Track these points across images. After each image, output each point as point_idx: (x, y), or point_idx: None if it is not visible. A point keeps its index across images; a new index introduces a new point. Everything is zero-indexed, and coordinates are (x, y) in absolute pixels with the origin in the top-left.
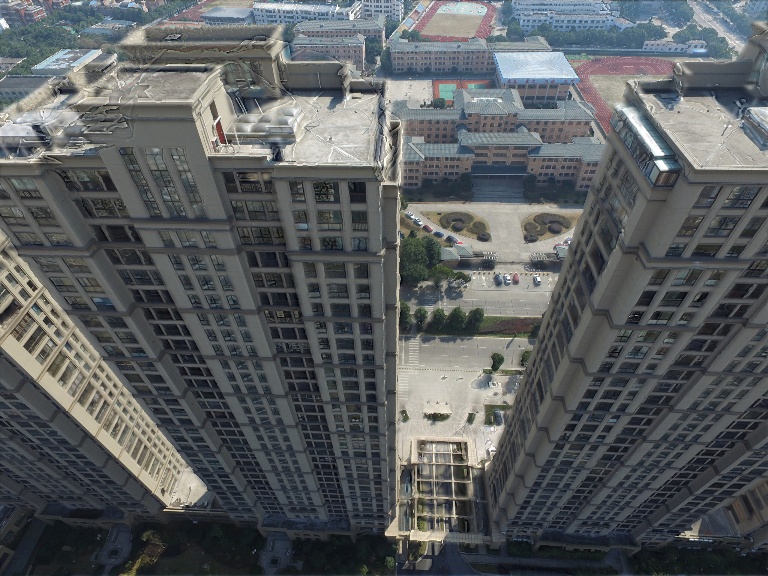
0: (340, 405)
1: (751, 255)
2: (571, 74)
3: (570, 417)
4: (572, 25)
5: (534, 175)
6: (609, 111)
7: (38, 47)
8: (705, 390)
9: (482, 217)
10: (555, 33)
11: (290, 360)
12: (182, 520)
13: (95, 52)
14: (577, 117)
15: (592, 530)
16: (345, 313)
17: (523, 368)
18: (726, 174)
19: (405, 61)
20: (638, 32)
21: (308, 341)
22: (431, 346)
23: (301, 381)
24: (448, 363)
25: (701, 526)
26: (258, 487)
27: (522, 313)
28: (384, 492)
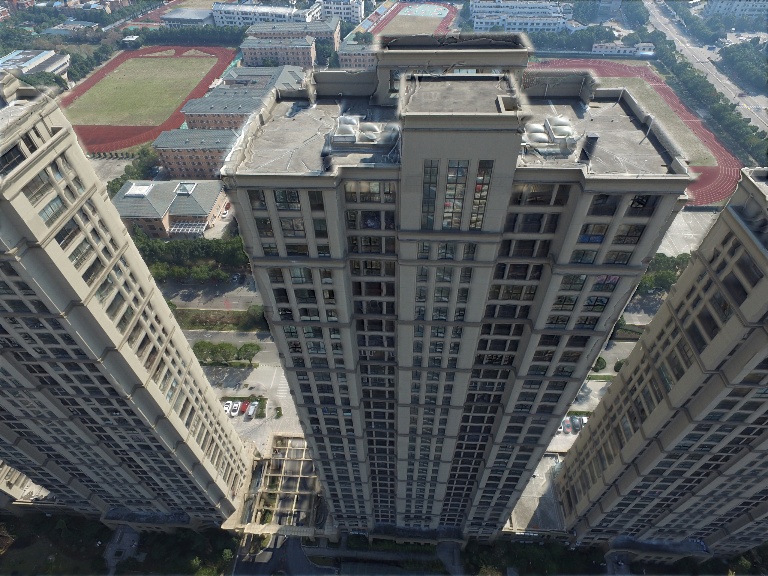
0: (89, 398)
1: (340, 255)
2: None
3: (306, 411)
4: (524, 27)
5: None
6: None
7: None
8: (414, 385)
9: None
10: (506, 35)
11: (22, 354)
12: (35, 513)
13: (47, 53)
14: None
15: (420, 524)
16: (26, 309)
17: None
18: (260, 179)
19: (353, 63)
20: (587, 35)
21: (12, 336)
22: None
23: (49, 375)
24: None
25: (531, 520)
26: (86, 480)
27: None
28: (196, 485)
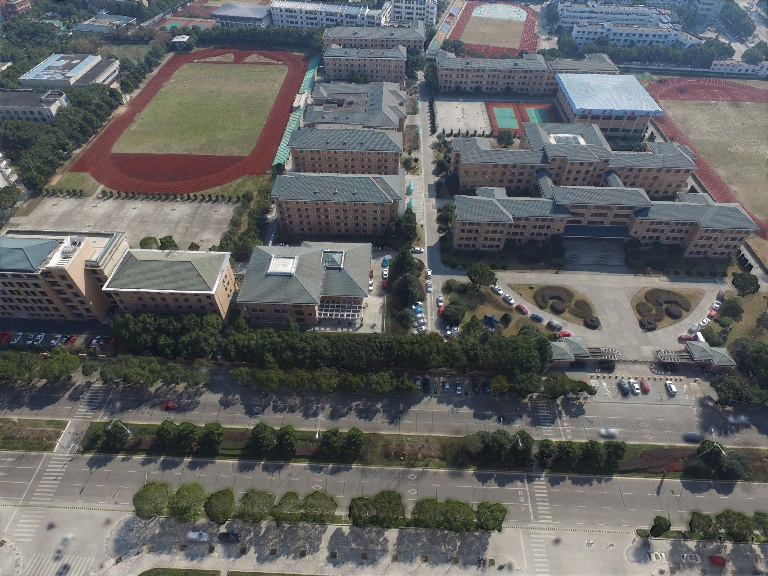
0: None
1: None
2: (653, 105)
3: None
4: (631, 39)
5: (637, 238)
6: (693, 148)
7: (24, 47)
8: None
9: (583, 293)
10: (614, 48)
11: None
12: None
13: (94, 58)
14: (677, 164)
15: None
16: None
17: (685, 527)
18: None
19: (453, 79)
20: (707, 50)
21: None
22: (562, 491)
23: None
24: (589, 519)
25: None
26: None
27: (664, 439)
28: None
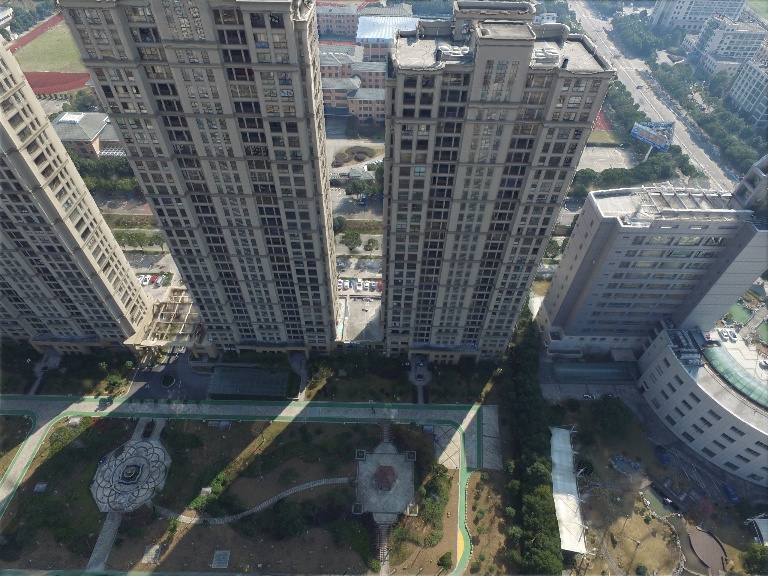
0: (4, 195)
1: (132, 57)
2: None
3: (152, 201)
4: None
5: (355, 116)
6: None
7: None
8: (215, 175)
9: None
10: (427, 3)
11: None
12: None
13: None
14: None
15: (273, 336)
16: None
17: None
18: (74, 2)
19: None
20: None
21: None
22: None
23: None
24: None
25: (357, 336)
26: (14, 299)
27: None
28: (96, 294)
